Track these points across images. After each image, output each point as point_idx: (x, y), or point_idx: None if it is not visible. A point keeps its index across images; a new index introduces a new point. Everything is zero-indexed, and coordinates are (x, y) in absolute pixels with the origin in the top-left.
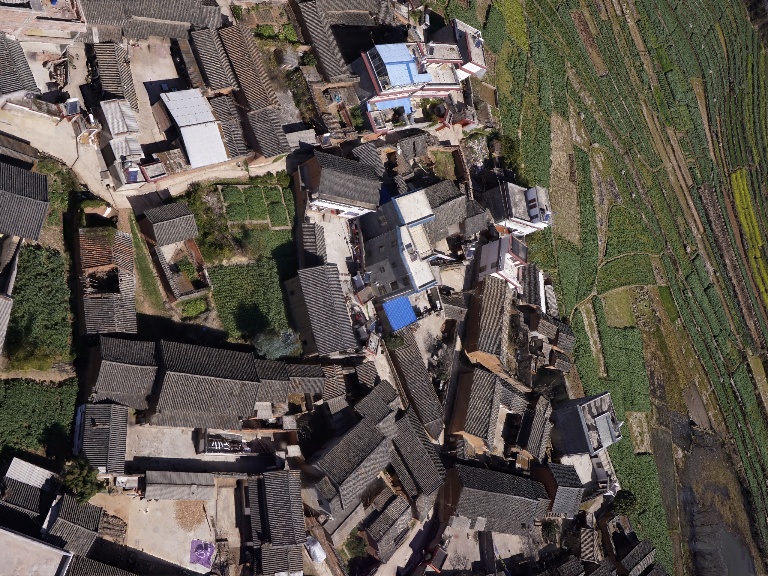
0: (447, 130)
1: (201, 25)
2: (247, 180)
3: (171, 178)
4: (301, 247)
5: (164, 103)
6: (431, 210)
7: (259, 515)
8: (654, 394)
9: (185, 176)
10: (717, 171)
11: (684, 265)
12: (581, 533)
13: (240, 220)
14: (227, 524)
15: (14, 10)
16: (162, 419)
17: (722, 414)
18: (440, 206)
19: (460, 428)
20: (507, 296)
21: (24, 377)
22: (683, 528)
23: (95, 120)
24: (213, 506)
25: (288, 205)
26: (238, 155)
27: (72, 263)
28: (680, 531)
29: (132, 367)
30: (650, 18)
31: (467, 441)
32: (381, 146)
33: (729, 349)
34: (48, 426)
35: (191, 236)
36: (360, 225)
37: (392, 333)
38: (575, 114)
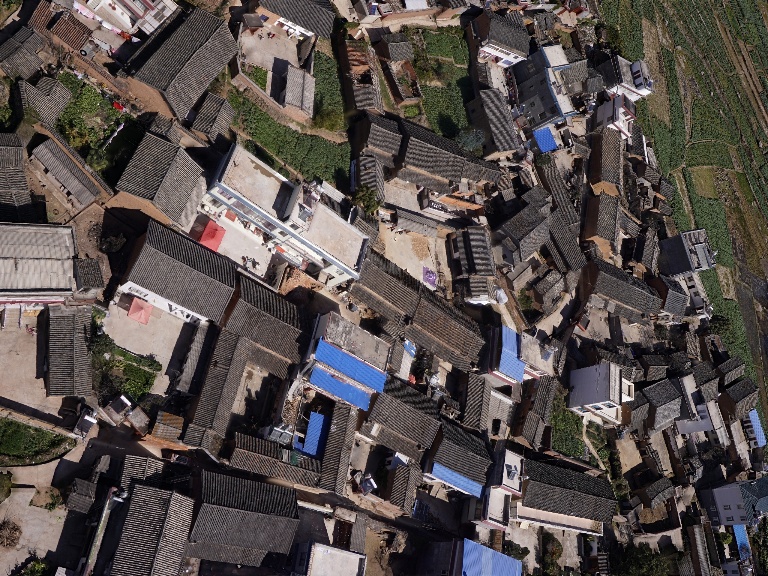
0: (565, 16)
1: None
2: (436, 29)
3: (390, 20)
4: (476, 81)
5: None
6: (567, 61)
7: (465, 257)
8: (736, 257)
9: (398, 20)
10: None
11: (758, 157)
12: (686, 335)
13: (435, 55)
14: (442, 263)
15: None
16: (404, 175)
17: None
18: None
19: (592, 234)
20: (621, 144)
21: (320, 135)
22: (765, 366)
23: None
24: (434, 248)
25: (464, 50)
26: (434, 6)
27: (339, 67)
28: (763, 368)
29: (388, 133)
30: None
31: (597, 246)
32: (523, 17)
33: None
34: (336, 169)
35: (410, 57)
36: (513, 72)
37: None
38: (660, 21)
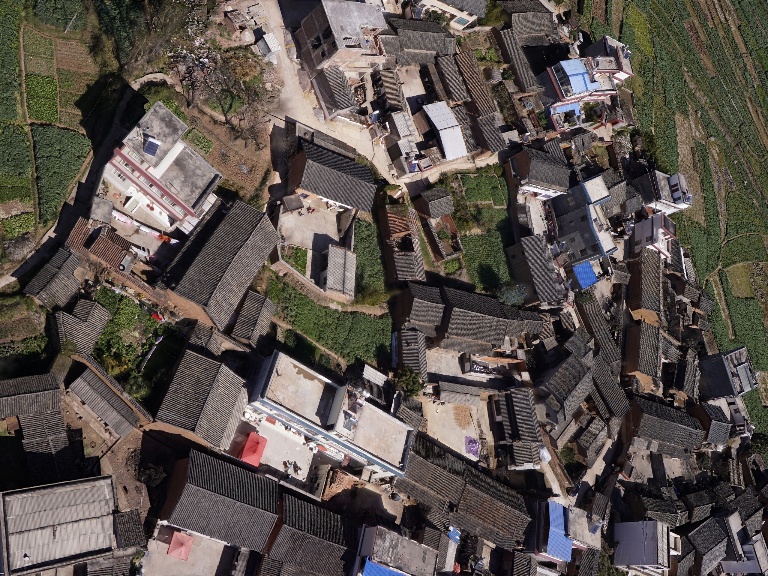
0: (601, 128)
1: (444, 53)
2: (475, 170)
3: None
4: (515, 222)
5: (426, 113)
6: None
7: (508, 421)
8: None
9: (437, 168)
10: None
11: None
12: (729, 463)
13: (474, 201)
14: (485, 428)
15: (353, 50)
16: (446, 344)
17: None
18: (609, 190)
19: (634, 369)
20: (660, 265)
21: (360, 311)
22: None
23: None
24: (476, 413)
25: (503, 189)
26: (473, 151)
27: (379, 231)
28: None
29: (430, 304)
30: (749, 23)
31: (639, 380)
32: (561, 142)
33: None
34: (377, 346)
35: (450, 212)
36: (552, 205)
37: (580, 291)
38: (693, 112)
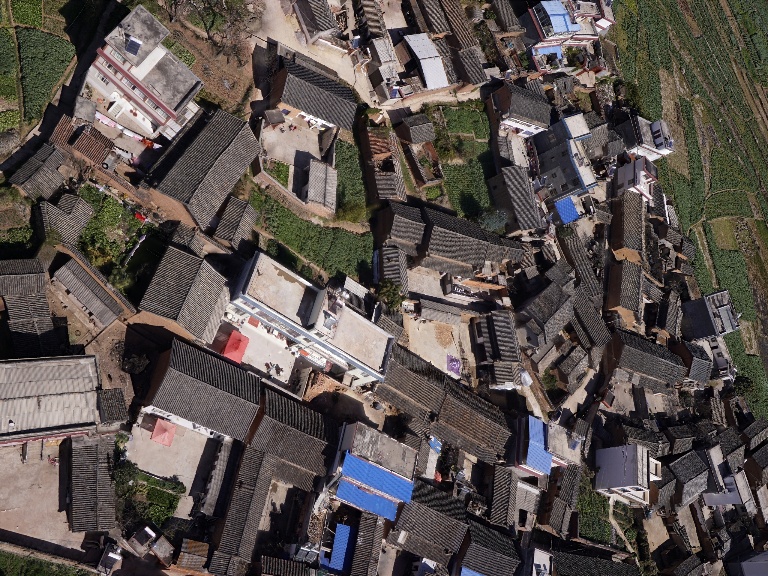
0: (584, 76)
1: None
2: (456, 104)
3: (411, 99)
4: (497, 155)
5: (407, 42)
6: (588, 130)
7: (489, 342)
8: (758, 309)
9: (419, 98)
10: None
11: None
12: (711, 401)
13: (456, 132)
14: (466, 349)
15: None
16: (427, 263)
17: None
18: (591, 130)
19: (615, 305)
20: (642, 207)
21: (342, 227)
22: None
23: None
24: (457, 334)
25: (485, 124)
26: (454, 83)
27: (360, 153)
28: None
29: (411, 222)
30: None
31: (621, 316)
32: (543, 83)
33: None
34: (359, 262)
35: (431, 139)
36: (534, 142)
37: (562, 226)
38: (677, 69)
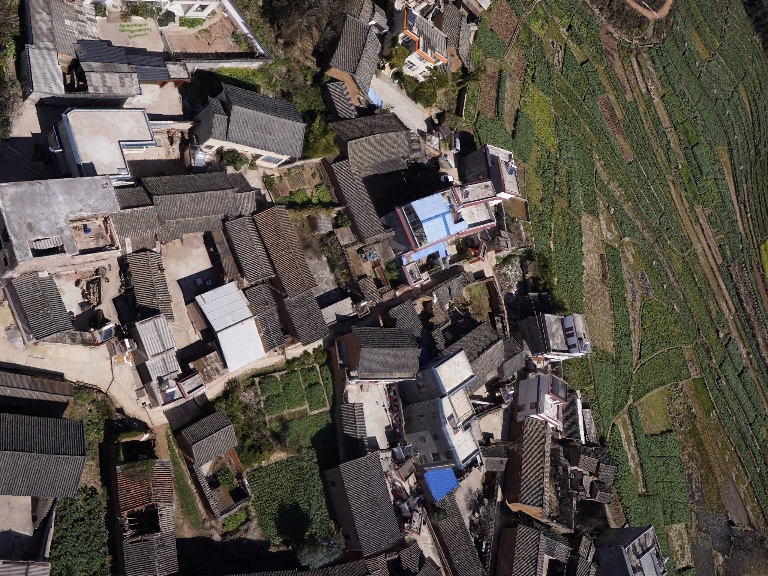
0: None
1: (235, 213)
2: (284, 365)
3: None
4: (340, 429)
5: (200, 306)
6: (471, 371)
7: None
8: (693, 499)
9: None
10: (746, 244)
11: (717, 352)
12: None
13: (278, 412)
14: None
15: (48, 258)
16: None
17: (760, 506)
18: (479, 357)
19: None
20: (547, 437)
21: None
22: None
23: (130, 341)
24: None
25: (326, 384)
26: (275, 346)
27: (109, 499)
28: None
29: None
30: (675, 91)
31: None
32: (417, 298)
33: (765, 435)
34: None
35: (230, 447)
36: None
37: (434, 503)
38: (605, 209)
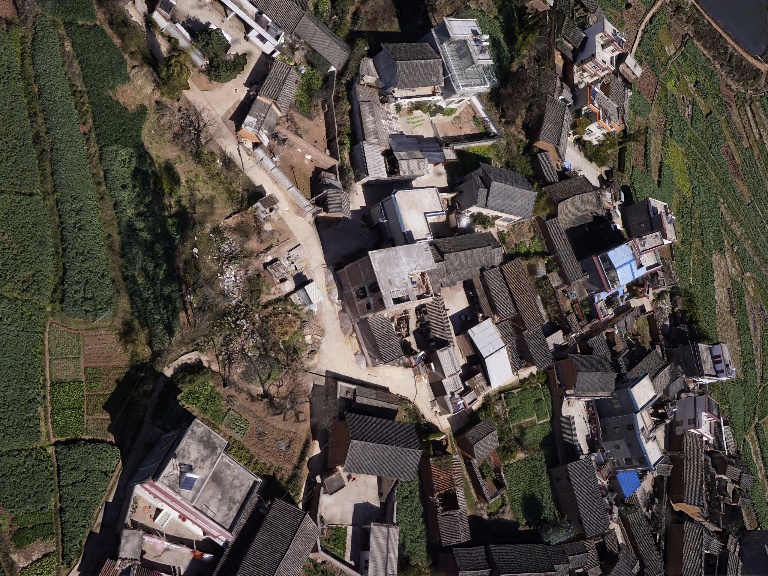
0: None
1: (490, 265)
2: (518, 383)
3: None
4: (559, 436)
5: (471, 338)
6: (654, 392)
7: None
8: None
9: None
10: None
11: None
12: None
13: (518, 421)
14: None
15: None
16: None
17: None
18: (653, 380)
19: None
20: None
21: None
22: None
23: None
24: None
25: (547, 400)
26: (518, 369)
27: (421, 483)
28: None
29: (476, 572)
30: None
31: None
32: (604, 330)
33: None
34: None
35: (495, 447)
36: (596, 407)
37: (623, 499)
38: (729, 247)
